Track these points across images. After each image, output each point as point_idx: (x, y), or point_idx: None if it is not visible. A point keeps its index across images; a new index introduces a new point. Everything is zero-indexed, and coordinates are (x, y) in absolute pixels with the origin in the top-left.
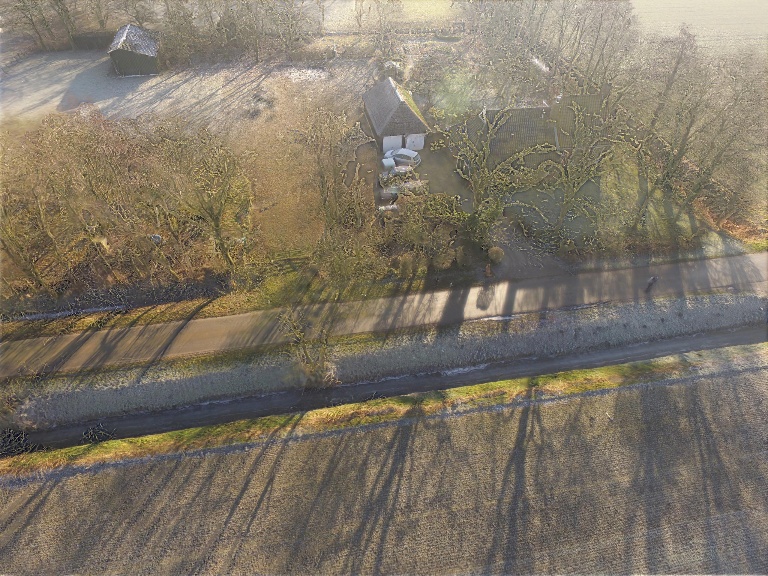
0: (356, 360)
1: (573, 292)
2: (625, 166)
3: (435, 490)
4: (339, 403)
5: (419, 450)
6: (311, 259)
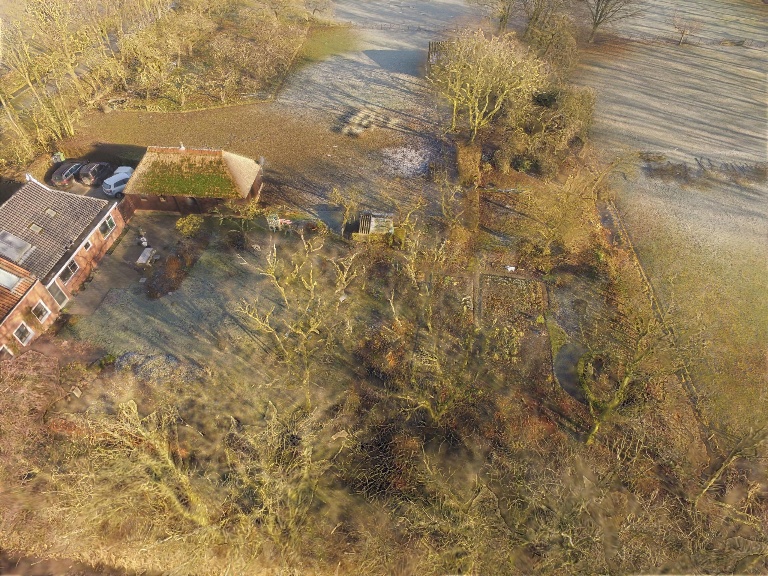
0: None
1: None
2: None
3: None
4: None
5: None
6: None
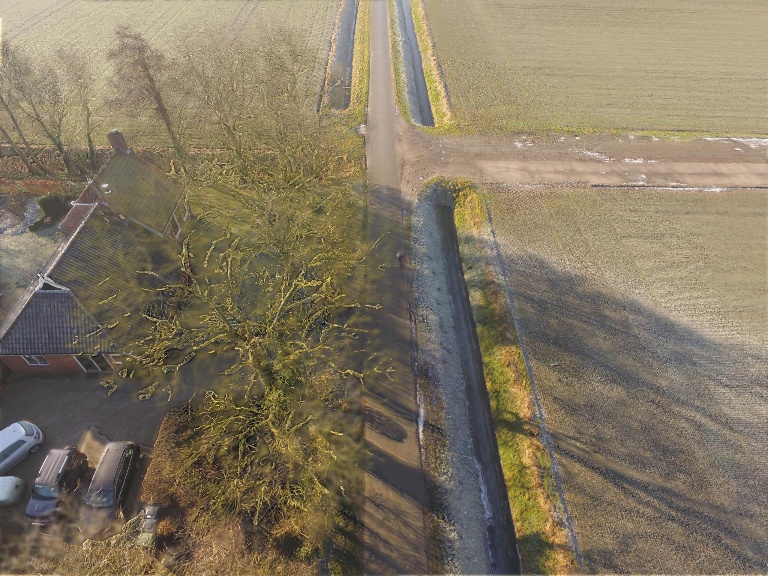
0: None
1: (392, 327)
2: (201, 195)
3: None
4: None
5: None
6: None
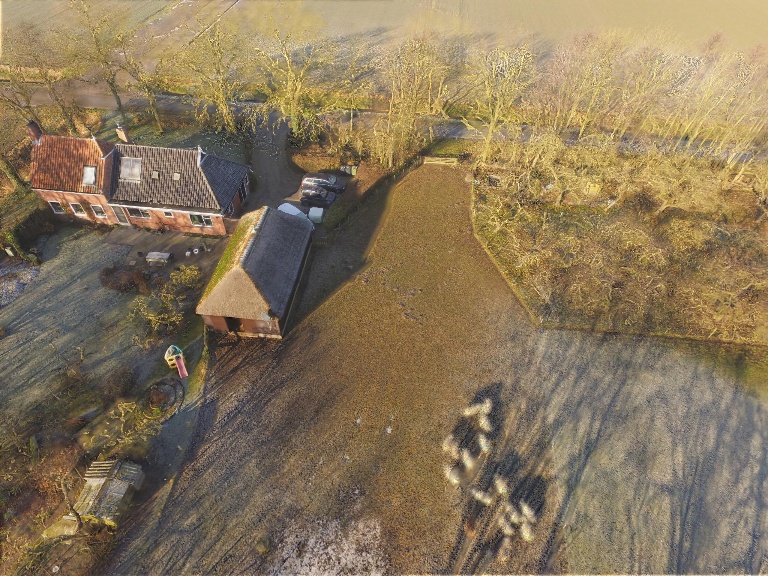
0: None
1: None
2: None
3: None
4: None
5: None
6: None
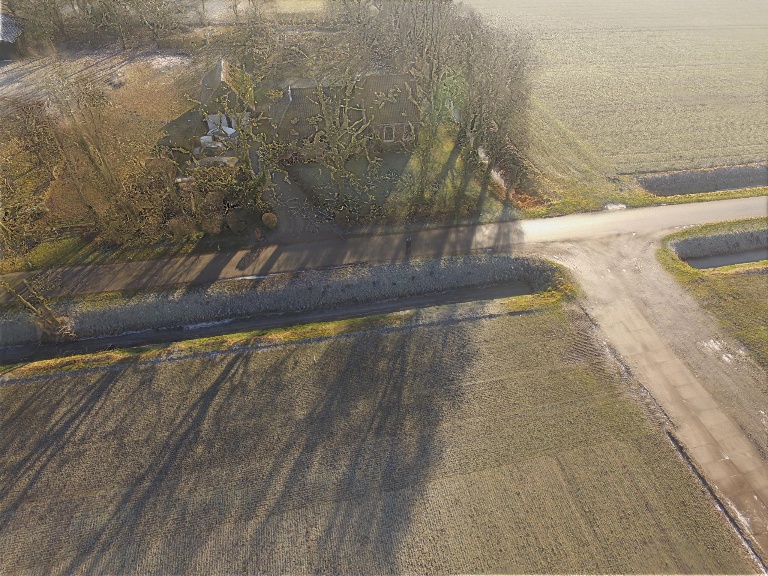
0: (97, 315)
1: (336, 254)
2: (442, 144)
3: (115, 425)
4: (71, 354)
5: (116, 391)
6: (94, 227)
